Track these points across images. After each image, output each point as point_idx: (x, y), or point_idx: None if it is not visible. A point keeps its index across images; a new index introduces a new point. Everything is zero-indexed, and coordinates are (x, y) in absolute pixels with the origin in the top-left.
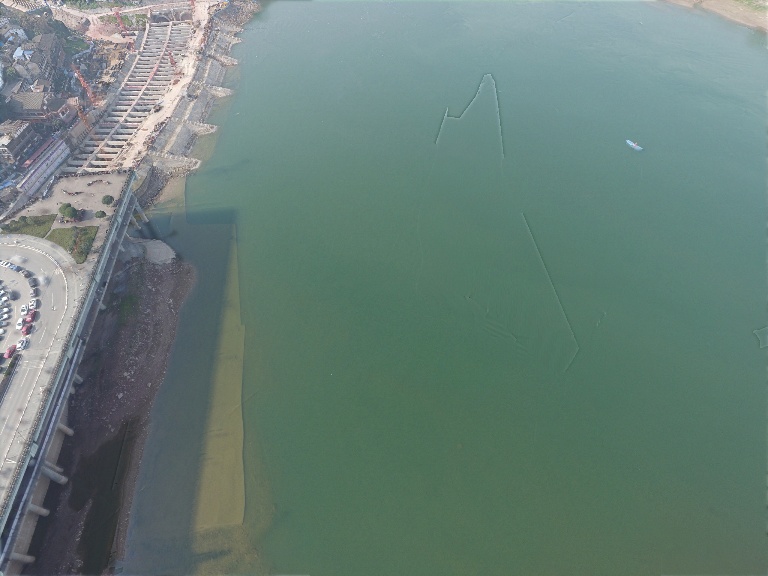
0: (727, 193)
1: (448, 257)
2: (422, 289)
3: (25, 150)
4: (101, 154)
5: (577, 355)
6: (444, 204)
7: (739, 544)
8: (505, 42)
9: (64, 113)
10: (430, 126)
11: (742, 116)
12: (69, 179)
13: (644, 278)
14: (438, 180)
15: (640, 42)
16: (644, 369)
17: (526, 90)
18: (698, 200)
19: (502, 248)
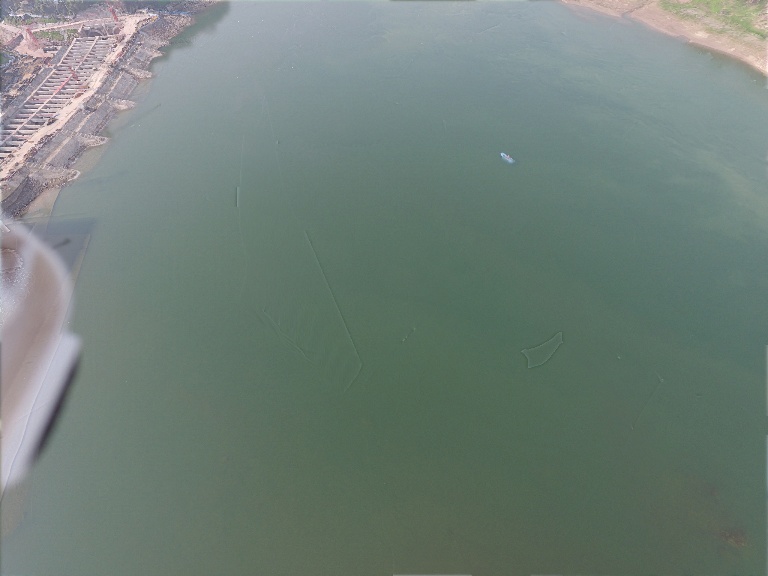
0: (600, 206)
1: (254, 270)
2: (240, 301)
3: None
4: None
5: (375, 371)
6: (248, 218)
7: (469, 570)
8: (415, 54)
9: None
10: (314, 138)
11: (631, 128)
12: None
13: (477, 293)
14: (243, 194)
15: (555, 53)
16: (442, 386)
17: (424, 102)
18: (547, 214)
19: (291, 262)
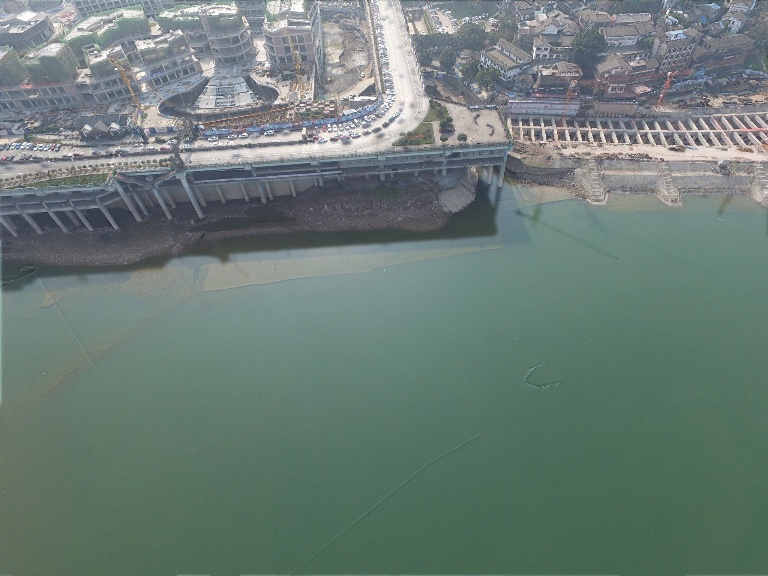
0: None
1: (393, 435)
2: None
3: (554, 88)
4: None
5: None
6: (445, 411)
7: None
8: None
9: (616, 90)
10: None
11: None
12: (495, 114)
13: None
14: None
15: None
16: None
17: None
18: None
19: (363, 489)
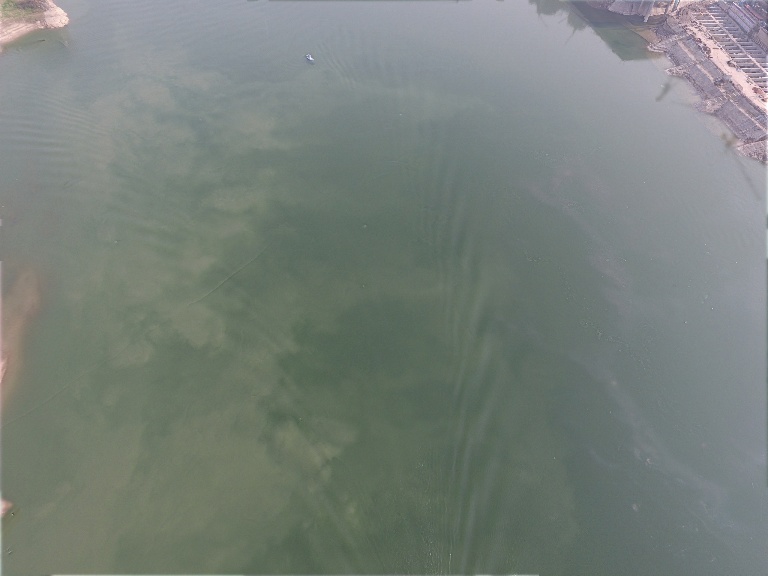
0: (256, 61)
1: None
2: None
3: None
4: (723, 34)
5: None
6: None
7: None
8: (378, 163)
9: None
10: (474, 75)
11: (190, 82)
12: None
13: None
14: None
15: (174, 186)
16: None
17: (372, 117)
18: None
19: None
